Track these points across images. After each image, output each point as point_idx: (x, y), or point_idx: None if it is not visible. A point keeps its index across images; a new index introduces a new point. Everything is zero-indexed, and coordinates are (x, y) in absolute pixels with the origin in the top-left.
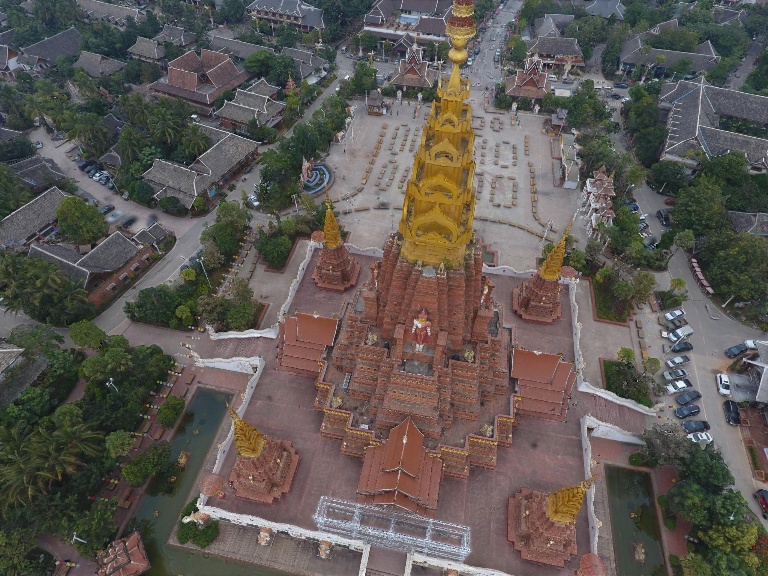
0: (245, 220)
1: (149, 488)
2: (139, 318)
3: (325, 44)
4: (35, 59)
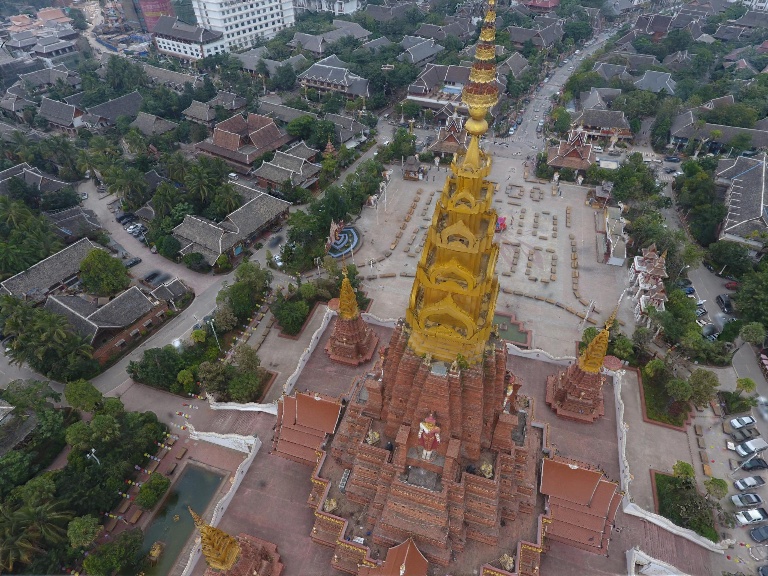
0: (264, 281)
1: None
2: (141, 379)
3: (367, 111)
4: (97, 118)
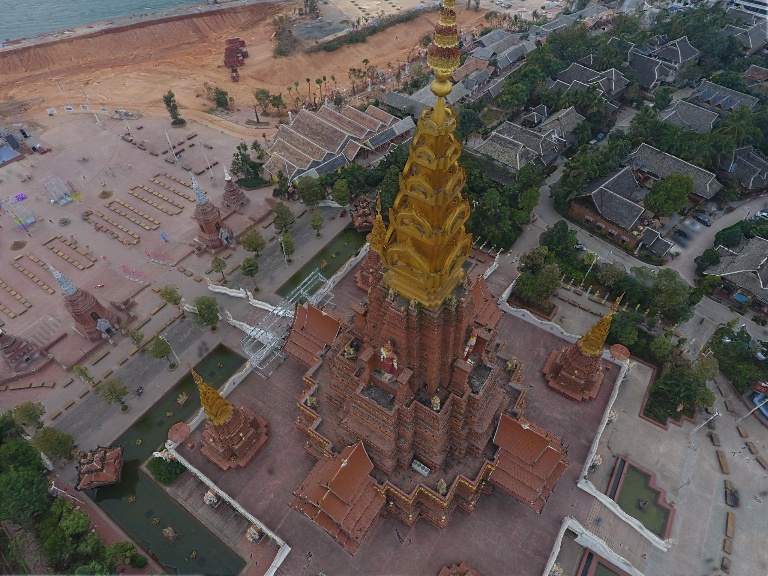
0: (670, 306)
1: None
2: None
3: None
4: None
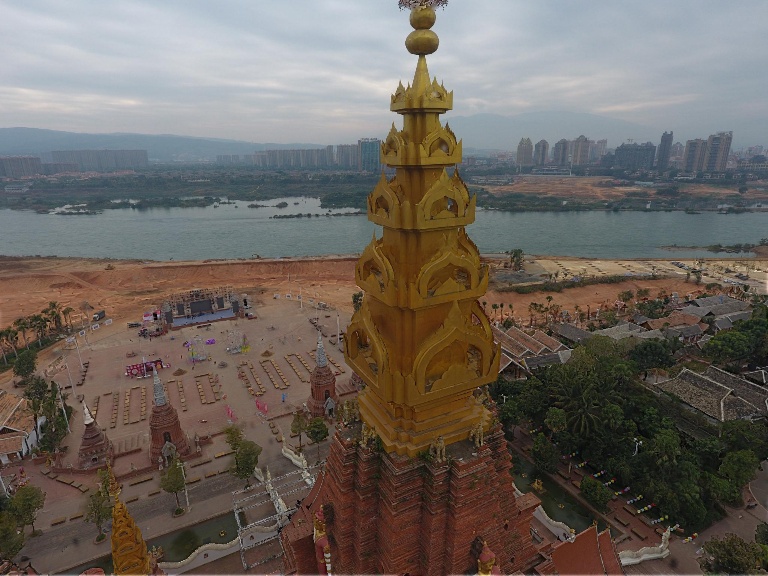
0: None
1: (529, 464)
2: None
3: None
4: None
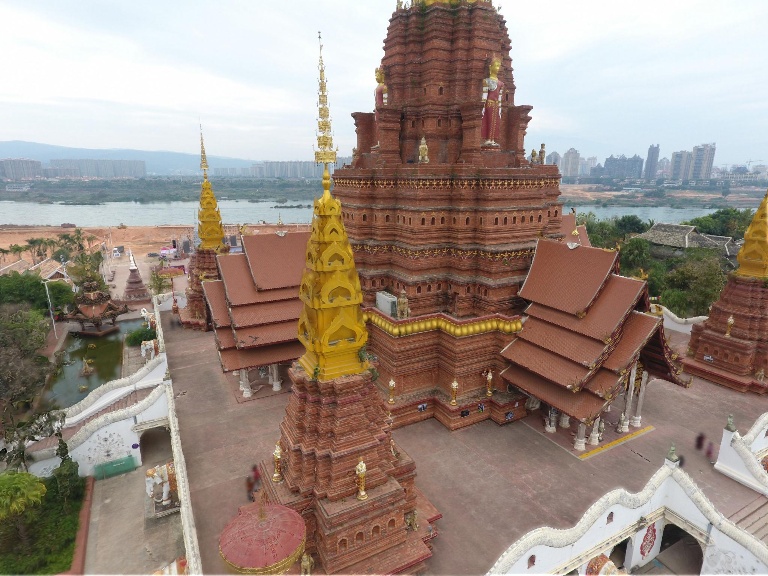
0: None
1: None
2: None
3: None
4: None
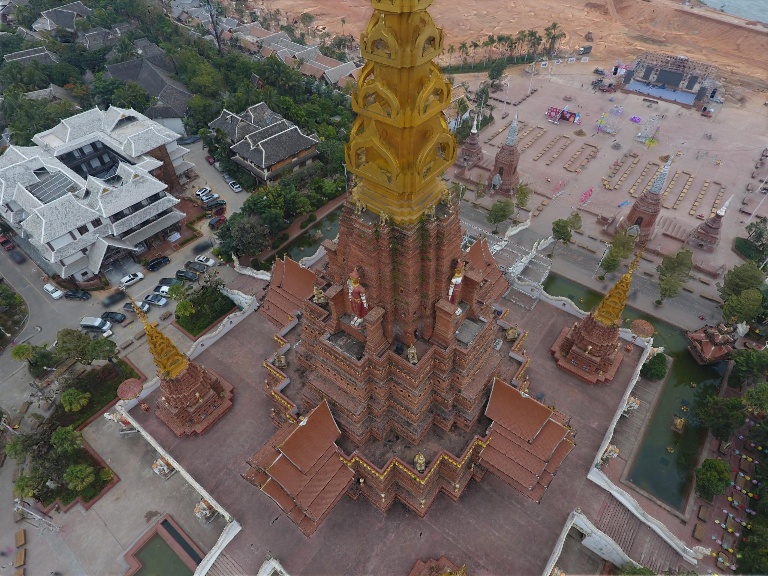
0: None
1: None
2: None
3: None
4: None
